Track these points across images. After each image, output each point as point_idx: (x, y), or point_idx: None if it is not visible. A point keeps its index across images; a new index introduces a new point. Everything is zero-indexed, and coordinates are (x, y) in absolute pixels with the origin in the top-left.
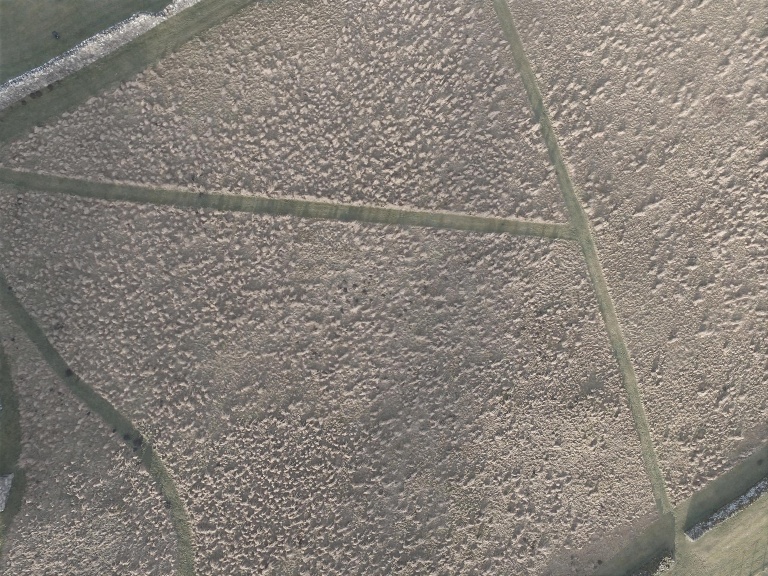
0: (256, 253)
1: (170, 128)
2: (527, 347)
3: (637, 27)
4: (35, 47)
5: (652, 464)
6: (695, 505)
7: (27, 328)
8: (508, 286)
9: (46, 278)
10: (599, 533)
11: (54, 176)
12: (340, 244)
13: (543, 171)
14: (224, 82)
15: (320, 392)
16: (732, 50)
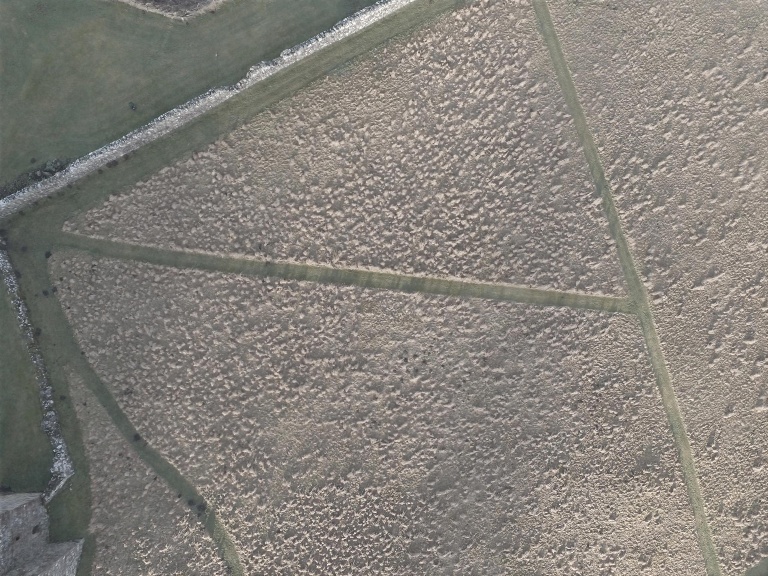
0: (319, 322)
1: (239, 198)
2: (584, 420)
3: (700, 101)
4: (112, 117)
5: (706, 539)
6: None
7: (98, 392)
8: (566, 359)
9: (117, 344)
10: None
11: (127, 243)
12: (402, 315)
13: (603, 245)
14: (293, 153)
15: (379, 461)
16: None
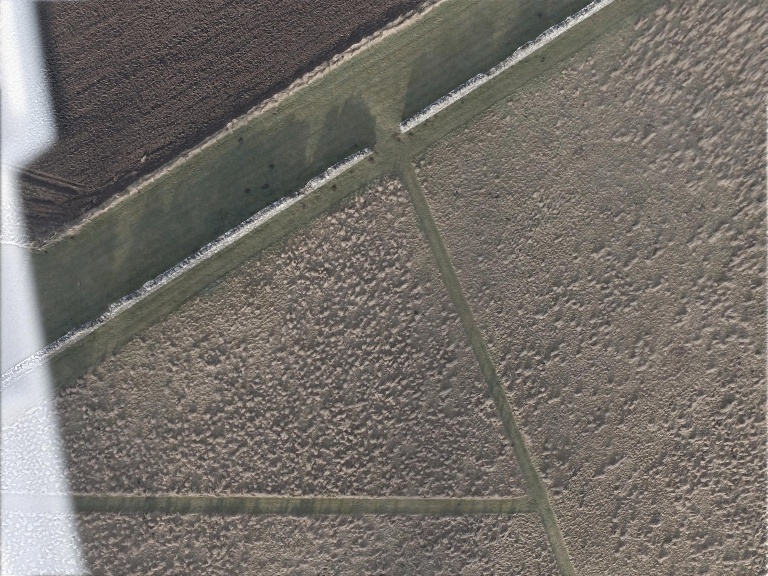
0: (206, 555)
1: (113, 433)
2: None
3: (590, 284)
4: None
5: None
6: None
7: None
8: (467, 567)
9: None
10: None
11: None
12: (292, 540)
13: (498, 445)
14: (167, 381)
15: None
16: (689, 299)
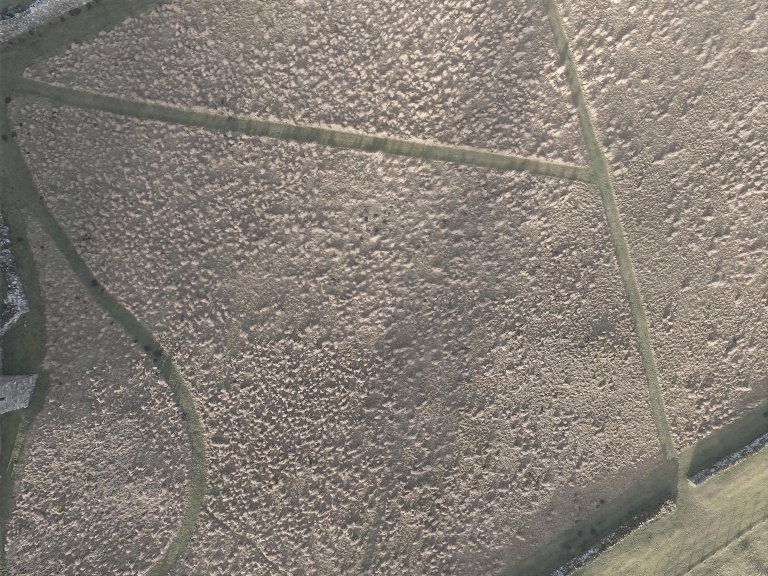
0: (281, 178)
1: (203, 52)
2: (541, 285)
3: None
4: None
5: (659, 409)
6: (699, 452)
7: (56, 237)
8: (526, 224)
9: (76, 190)
10: (603, 473)
11: (88, 92)
12: (363, 174)
13: (566, 114)
14: (257, 9)
15: (337, 317)
16: (759, 5)
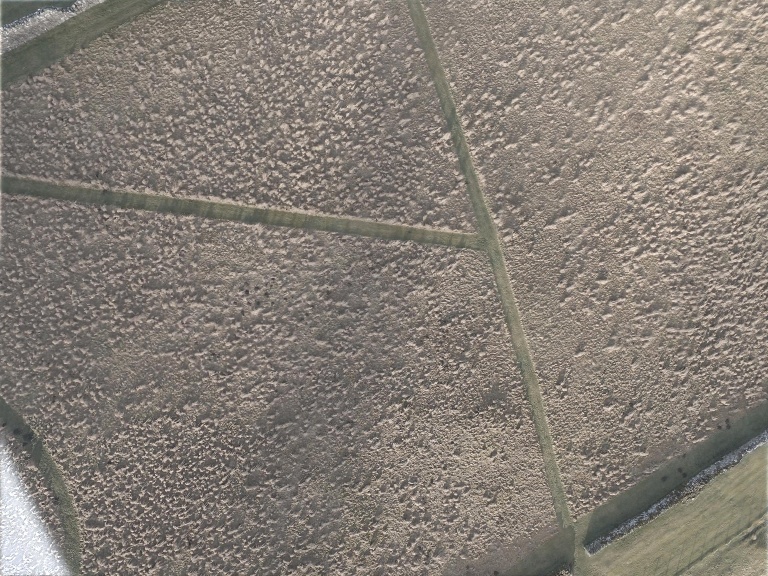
0: (158, 252)
1: (76, 124)
2: (429, 356)
3: (555, 39)
4: None
5: (554, 477)
6: (596, 519)
7: None
8: (412, 294)
9: None
10: (496, 544)
11: None
12: (243, 246)
13: (453, 180)
14: (132, 80)
15: (217, 393)
16: (652, 66)
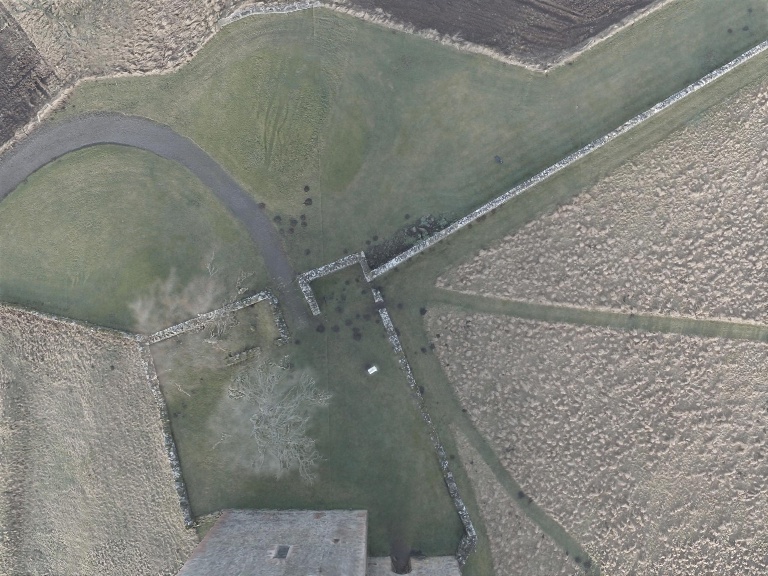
0: (685, 374)
1: (604, 250)
2: None
3: None
4: (479, 171)
5: None
6: None
7: (481, 450)
8: None
9: (496, 400)
10: None
11: (498, 298)
12: (764, 365)
13: None
14: (653, 205)
15: (746, 512)
16: None
